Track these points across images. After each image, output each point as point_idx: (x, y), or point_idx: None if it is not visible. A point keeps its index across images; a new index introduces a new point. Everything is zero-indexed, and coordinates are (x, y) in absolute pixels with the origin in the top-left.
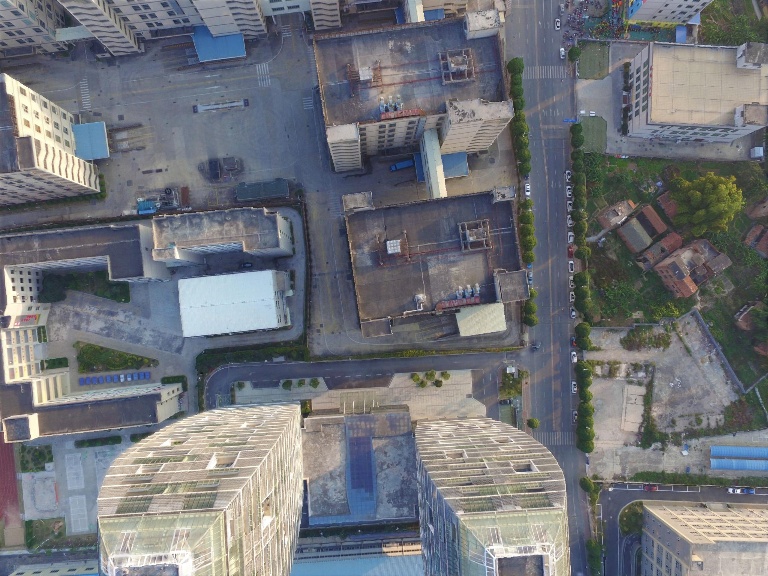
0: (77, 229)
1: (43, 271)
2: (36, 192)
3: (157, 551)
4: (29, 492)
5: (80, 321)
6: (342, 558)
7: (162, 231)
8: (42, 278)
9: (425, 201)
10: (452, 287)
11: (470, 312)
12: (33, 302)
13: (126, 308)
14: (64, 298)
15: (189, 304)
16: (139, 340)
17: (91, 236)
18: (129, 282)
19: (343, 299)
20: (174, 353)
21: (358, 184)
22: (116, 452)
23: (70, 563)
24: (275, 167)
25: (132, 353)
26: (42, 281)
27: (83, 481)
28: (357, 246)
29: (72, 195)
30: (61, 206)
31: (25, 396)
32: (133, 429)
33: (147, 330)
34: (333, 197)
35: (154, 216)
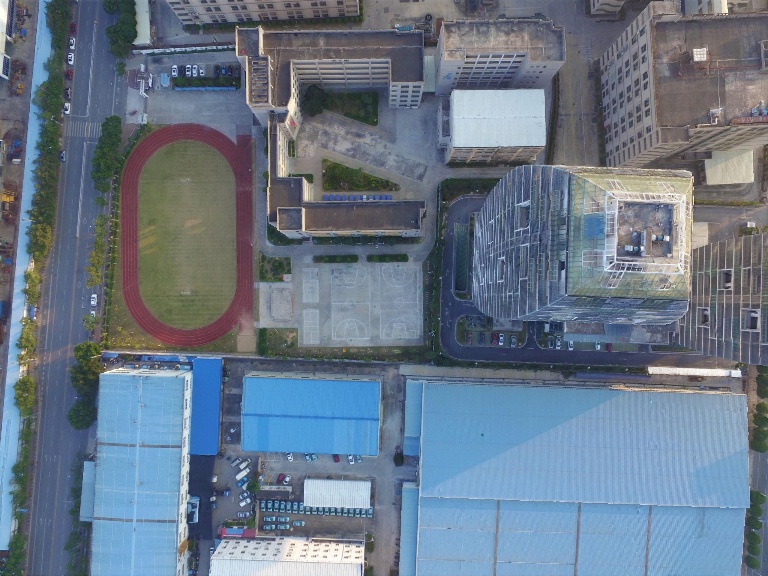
0: (363, 30)
1: (301, 85)
2: (311, 1)
3: (652, 192)
4: (265, 301)
5: (328, 140)
6: (576, 388)
7: (449, 36)
8: (300, 91)
9: (728, 17)
10: (747, 105)
11: (719, 161)
12: (298, 109)
13: (373, 131)
14: (321, 111)
15: (462, 114)
16: (383, 164)
17: (374, 39)
18: (378, 106)
19: (586, 141)
20: (416, 180)
21: (610, 30)
22: (352, 270)
23: (299, 373)
24: (530, 6)
25: (375, 176)
26: (307, 90)
27: (318, 295)
28: (656, 56)
29: (333, 15)
30: (319, 27)
31: (294, 191)
32: (370, 250)
33: (392, 155)
34: (584, 40)
35: (443, 21)
